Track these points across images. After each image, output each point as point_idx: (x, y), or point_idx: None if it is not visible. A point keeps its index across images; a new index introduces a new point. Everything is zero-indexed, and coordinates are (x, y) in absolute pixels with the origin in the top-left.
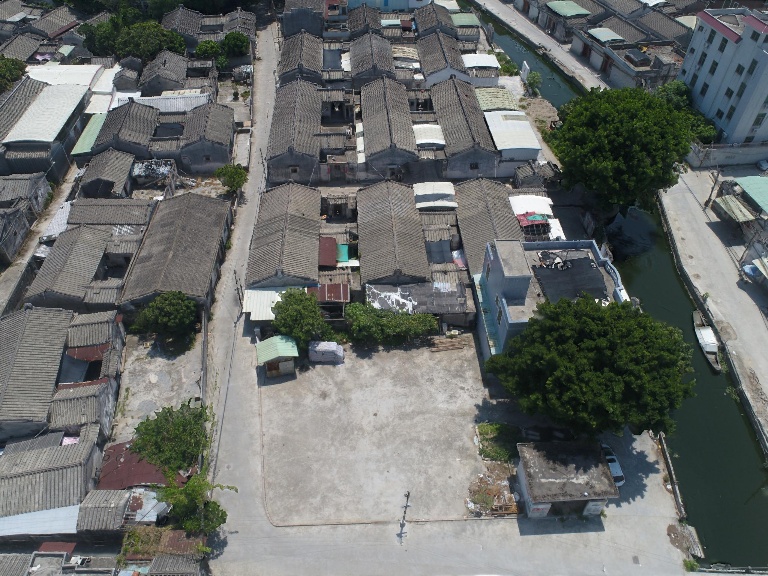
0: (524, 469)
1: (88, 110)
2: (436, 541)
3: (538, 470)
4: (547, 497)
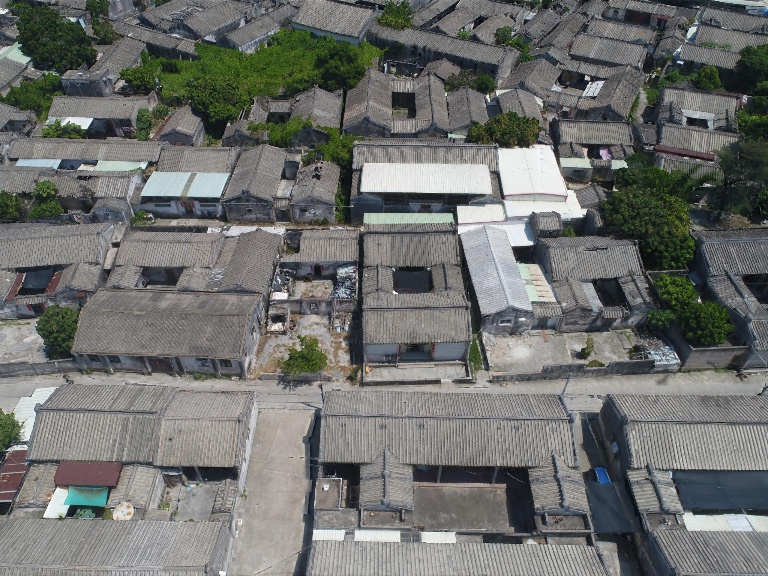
0: None
1: (463, 208)
2: None
3: None
4: None
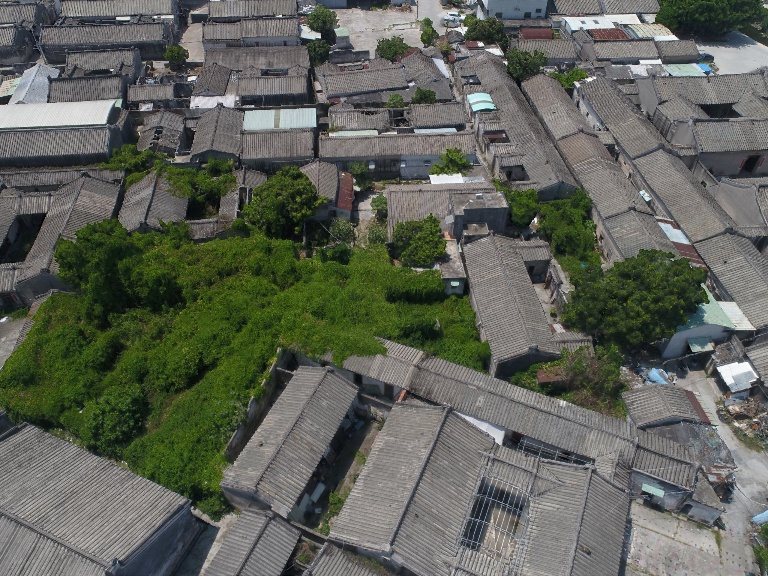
0: None
1: None
2: None
3: None
4: None
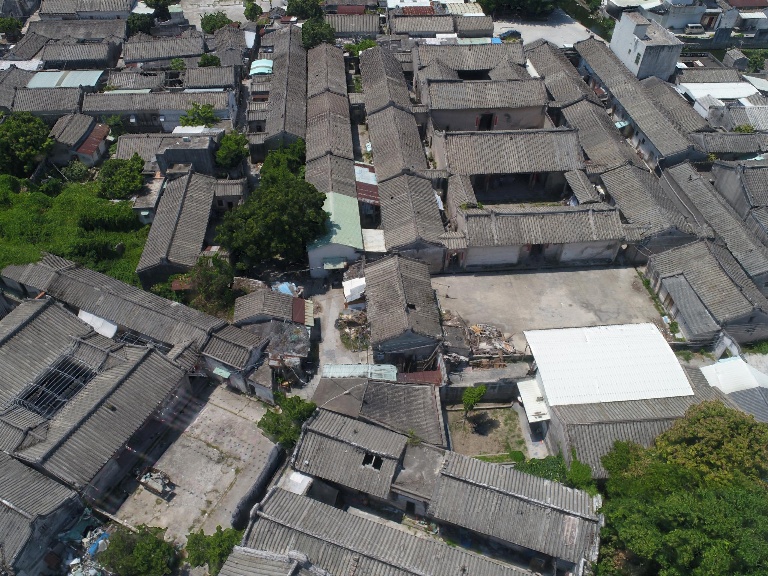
0: None
1: None
2: None
3: None
4: None
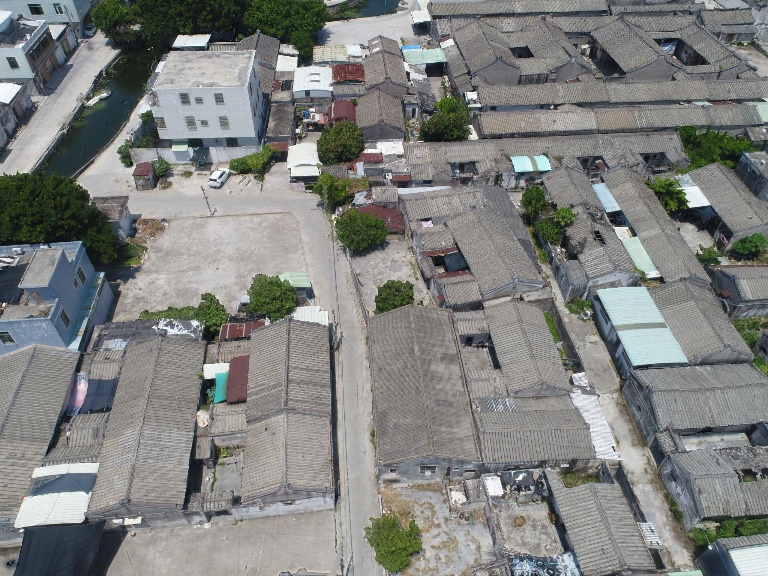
0: (124, 208)
1: None
2: (194, 210)
3: (115, 209)
4: (118, 198)
